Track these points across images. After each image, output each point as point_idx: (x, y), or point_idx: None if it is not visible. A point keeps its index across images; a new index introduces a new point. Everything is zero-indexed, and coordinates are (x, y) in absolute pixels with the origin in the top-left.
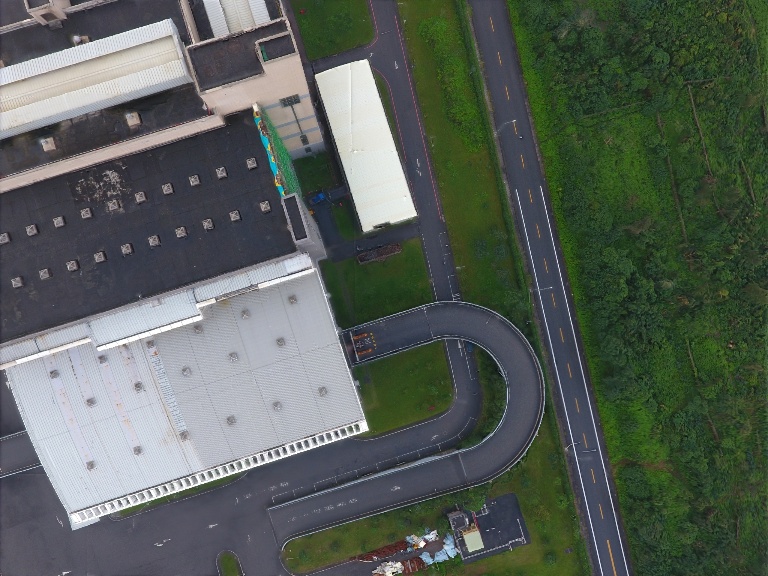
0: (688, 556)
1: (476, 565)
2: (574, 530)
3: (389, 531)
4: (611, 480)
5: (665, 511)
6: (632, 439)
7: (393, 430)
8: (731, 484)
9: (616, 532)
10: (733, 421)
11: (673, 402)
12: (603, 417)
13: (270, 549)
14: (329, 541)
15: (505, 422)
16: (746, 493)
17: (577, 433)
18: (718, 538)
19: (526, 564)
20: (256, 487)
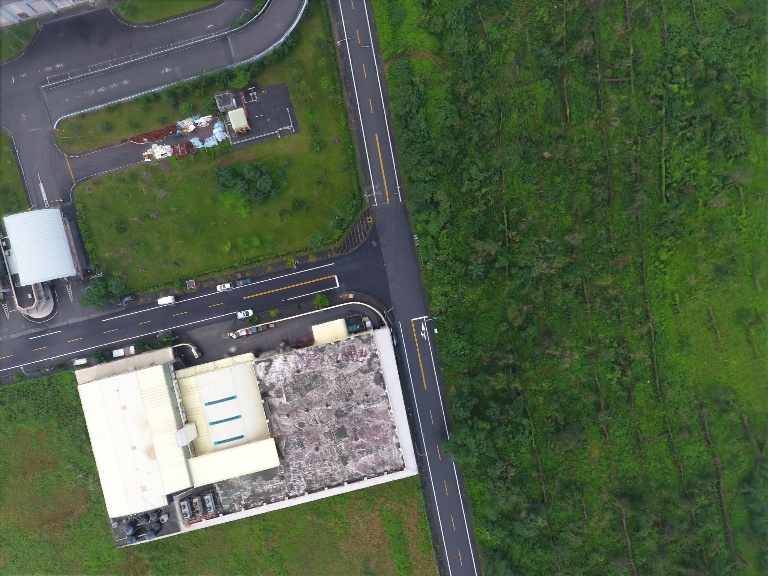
0: (445, 135)
1: (245, 151)
2: (341, 118)
3: (161, 116)
4: (382, 76)
5: (422, 85)
6: (402, 32)
7: (169, 18)
8: (498, 80)
9: (385, 127)
10: (503, 18)
11: (447, 2)
12: (376, 13)
13: (44, 128)
14: (101, 122)
15: (273, 3)
16: (513, 90)
17: (350, 29)
18: (479, 124)
19: (294, 153)
20: (32, 67)
